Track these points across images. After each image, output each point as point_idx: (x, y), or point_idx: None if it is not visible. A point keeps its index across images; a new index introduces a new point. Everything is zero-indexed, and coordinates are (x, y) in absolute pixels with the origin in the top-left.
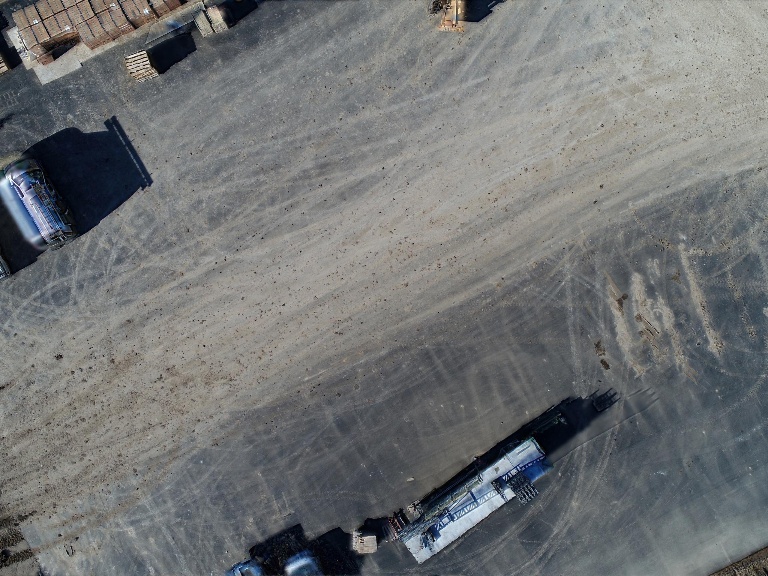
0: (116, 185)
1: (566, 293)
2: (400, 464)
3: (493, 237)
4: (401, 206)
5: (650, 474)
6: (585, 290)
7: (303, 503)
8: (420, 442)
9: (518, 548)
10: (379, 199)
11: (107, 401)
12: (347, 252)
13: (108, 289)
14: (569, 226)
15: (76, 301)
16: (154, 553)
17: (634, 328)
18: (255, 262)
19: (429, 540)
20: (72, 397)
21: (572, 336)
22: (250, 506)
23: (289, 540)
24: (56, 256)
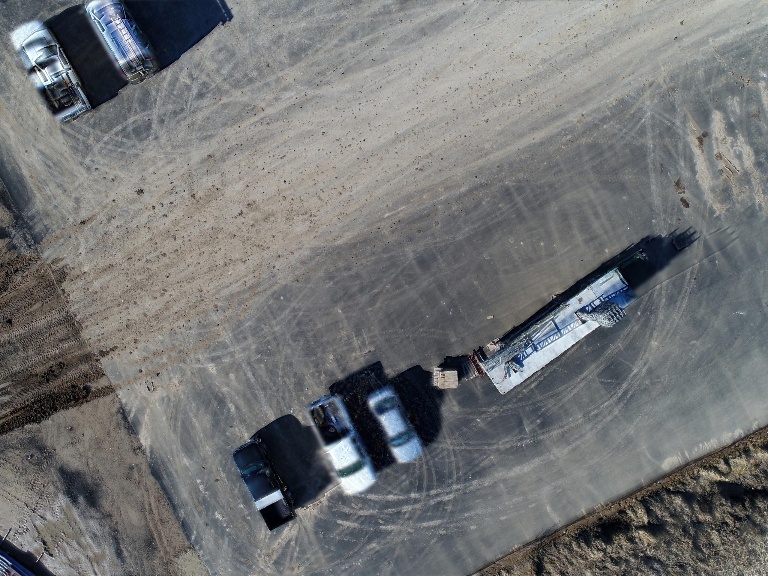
0: (196, 20)
1: (646, 130)
2: (480, 302)
3: (573, 73)
4: (481, 41)
5: (729, 314)
6: (665, 127)
7: (383, 340)
8: (500, 280)
9: (597, 387)
10: (459, 34)
11: (188, 236)
12: (427, 88)
13: (189, 124)
14: (649, 62)
15: (157, 136)
16: (234, 390)
17: (714, 166)
18: (335, 97)
19: (515, 364)
20: (153, 232)
21: (652, 174)
22: (330, 343)
23: (369, 377)
24: (137, 91)
